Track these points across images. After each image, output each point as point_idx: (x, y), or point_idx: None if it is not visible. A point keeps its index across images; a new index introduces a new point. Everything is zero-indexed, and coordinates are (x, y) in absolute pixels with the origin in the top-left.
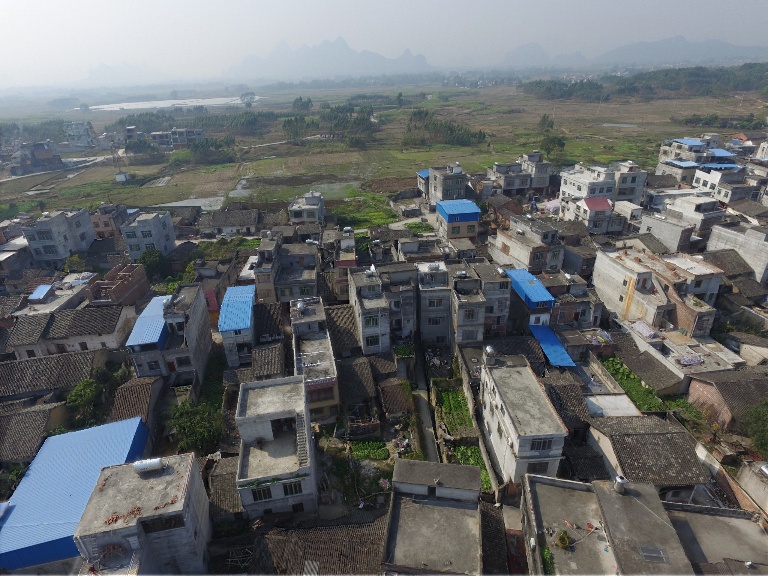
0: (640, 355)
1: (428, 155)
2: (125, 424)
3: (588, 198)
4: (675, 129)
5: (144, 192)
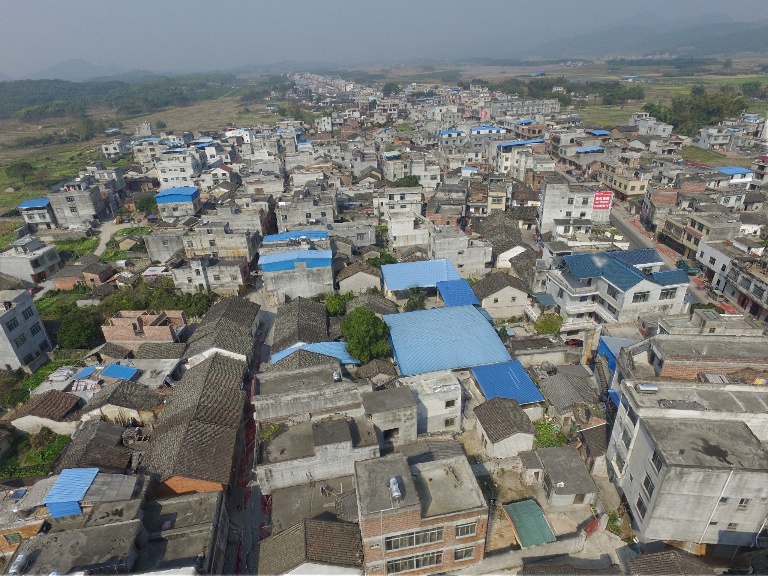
0: (356, 195)
1: None
2: (386, 268)
3: (219, 166)
4: (29, 151)
5: None
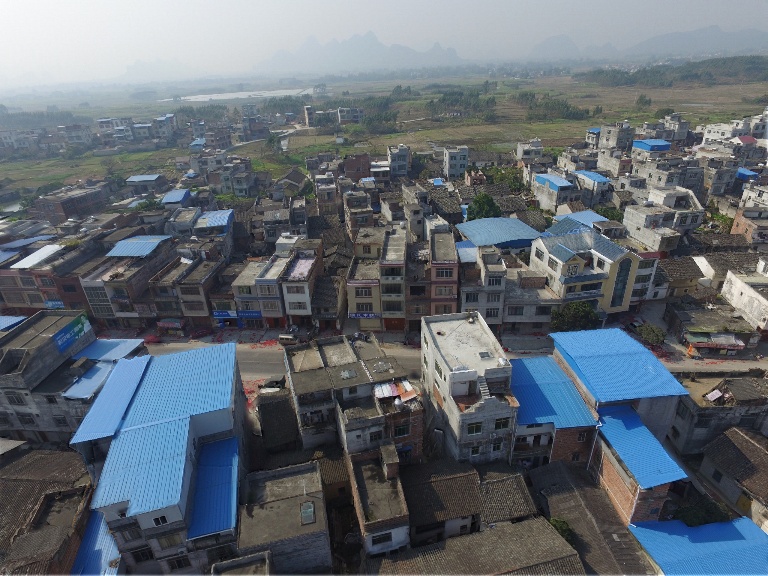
0: None
1: (556, 126)
2: None
3: (740, 136)
4: (749, 107)
5: (366, 149)
